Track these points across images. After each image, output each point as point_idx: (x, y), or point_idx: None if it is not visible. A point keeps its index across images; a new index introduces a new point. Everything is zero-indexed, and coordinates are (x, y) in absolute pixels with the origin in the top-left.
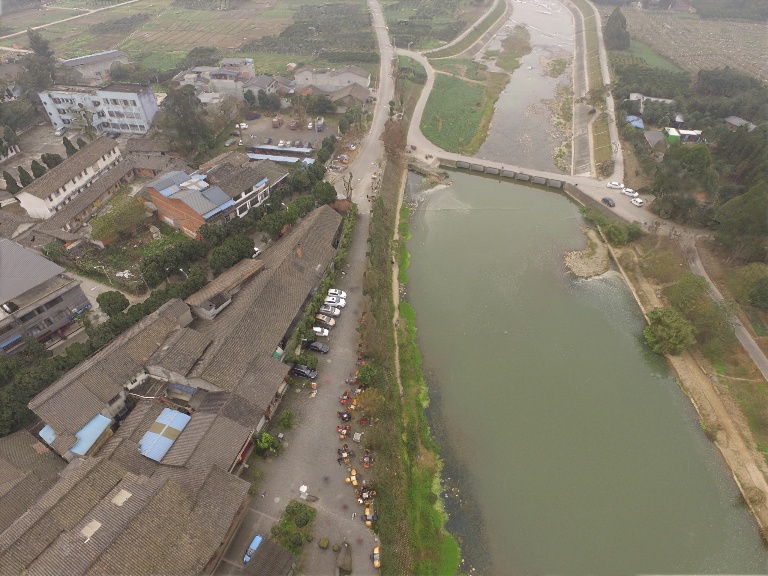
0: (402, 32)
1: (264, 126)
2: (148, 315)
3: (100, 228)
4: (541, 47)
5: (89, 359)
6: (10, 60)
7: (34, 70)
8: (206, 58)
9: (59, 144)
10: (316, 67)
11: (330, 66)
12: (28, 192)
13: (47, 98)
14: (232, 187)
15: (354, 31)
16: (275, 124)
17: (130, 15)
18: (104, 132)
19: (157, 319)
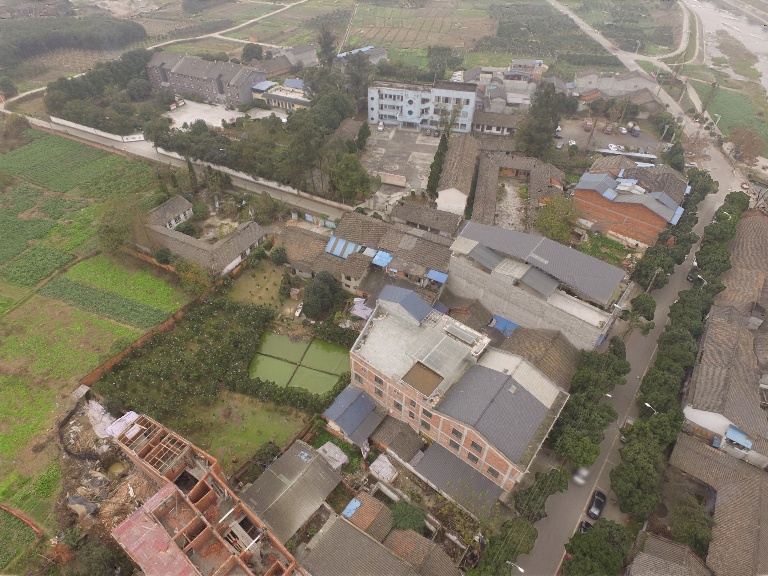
0: (619, 36)
1: (574, 129)
2: (708, 321)
3: (559, 228)
4: (765, 55)
5: (702, 363)
6: (269, 53)
7: (354, 66)
8: (452, 57)
9: (389, 139)
10: (600, 70)
11: (577, 69)
12: (457, 188)
13: (376, 94)
14: (673, 193)
15: (566, 33)
16: (589, 127)
17: (326, 11)
18: (421, 129)
19: (740, 327)
